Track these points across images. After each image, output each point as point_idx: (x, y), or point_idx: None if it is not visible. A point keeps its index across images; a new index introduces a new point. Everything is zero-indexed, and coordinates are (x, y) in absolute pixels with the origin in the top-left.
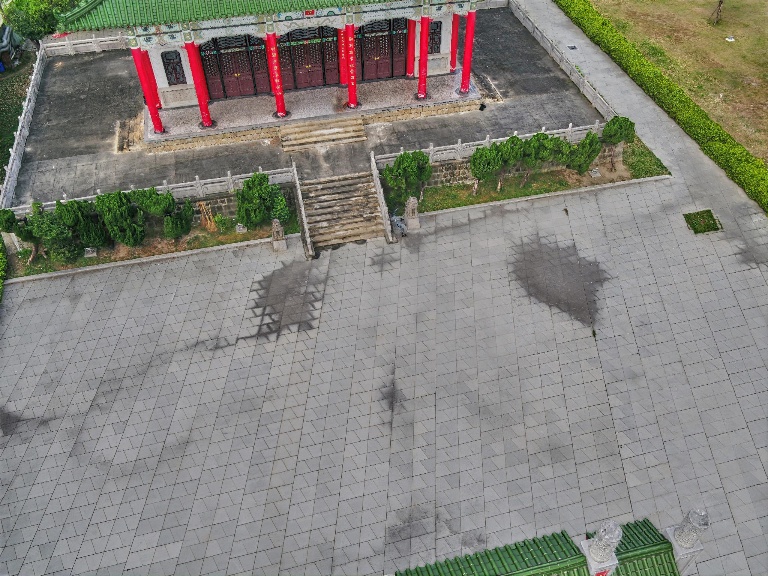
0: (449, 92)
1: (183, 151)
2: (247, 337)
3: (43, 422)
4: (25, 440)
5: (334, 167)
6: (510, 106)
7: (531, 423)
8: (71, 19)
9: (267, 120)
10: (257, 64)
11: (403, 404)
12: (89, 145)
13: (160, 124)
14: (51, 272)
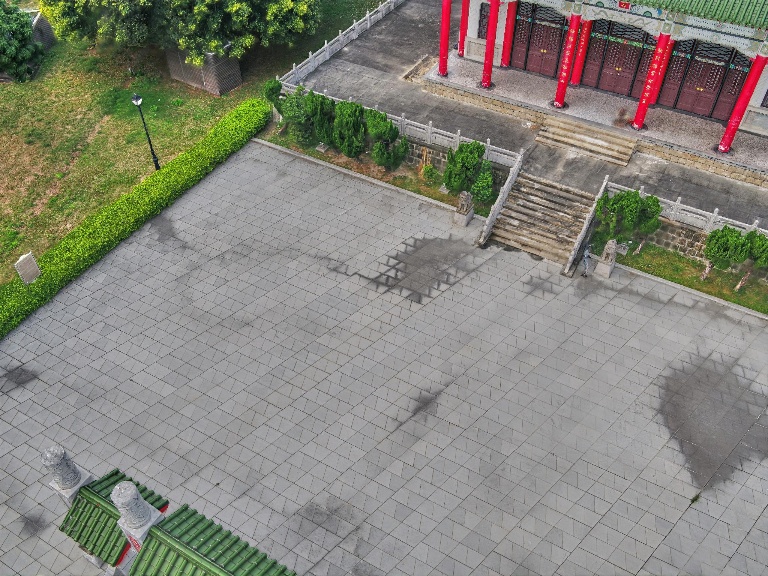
0: (761, 159)
1: (451, 100)
2: (364, 276)
3: (184, 247)
4: (164, 251)
5: (567, 175)
6: None
7: (527, 526)
8: None
9: (541, 104)
10: None
11: (428, 417)
12: (388, 64)
13: (445, 67)
14: (285, 147)
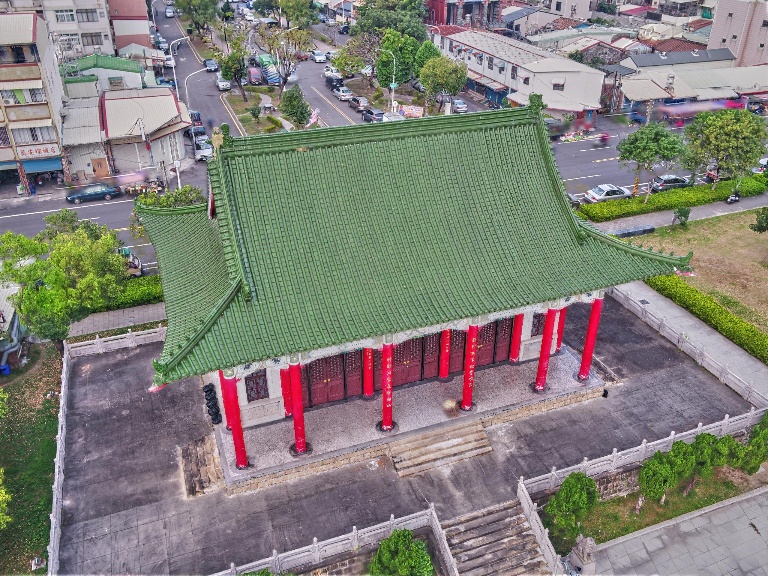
0: (567, 379)
1: (273, 488)
2: None
3: None
4: None
5: (470, 496)
6: (633, 389)
7: None
8: (172, 365)
9: (372, 436)
10: (351, 367)
11: None
12: (148, 488)
13: (245, 457)
14: None
